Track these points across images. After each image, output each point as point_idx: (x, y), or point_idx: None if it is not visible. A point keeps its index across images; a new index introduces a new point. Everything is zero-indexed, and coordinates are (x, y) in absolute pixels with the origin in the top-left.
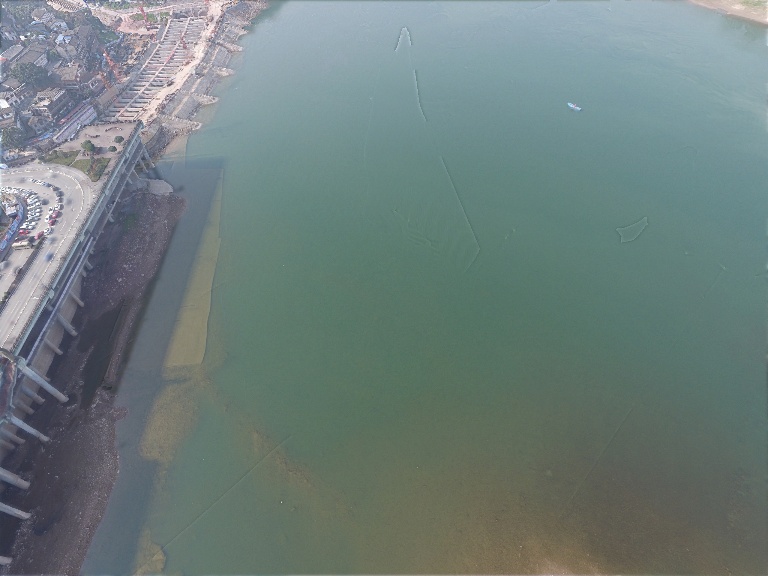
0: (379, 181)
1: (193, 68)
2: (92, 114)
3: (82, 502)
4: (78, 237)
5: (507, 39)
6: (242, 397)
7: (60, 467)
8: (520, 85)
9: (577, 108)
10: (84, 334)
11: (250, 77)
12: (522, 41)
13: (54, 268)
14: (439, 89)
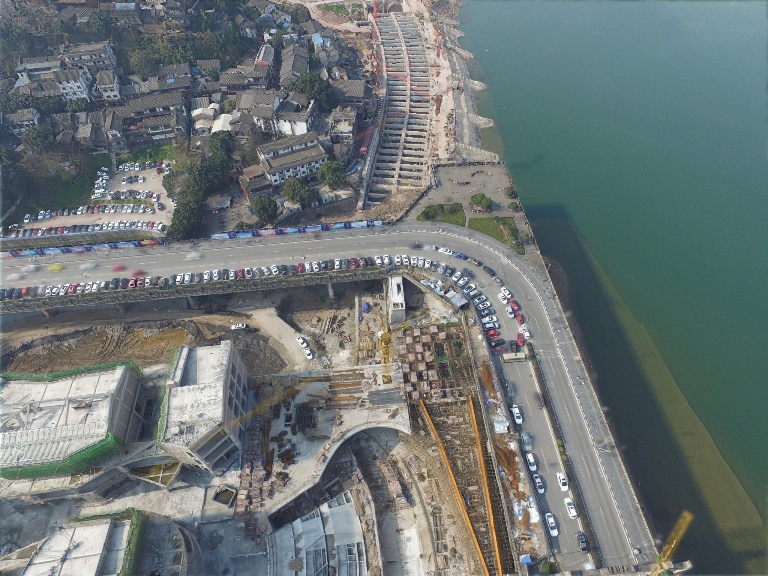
0: None
1: (456, 81)
2: (377, 139)
3: None
4: None
5: None
6: None
7: None
8: None
9: None
10: None
11: (511, 94)
12: None
13: (588, 398)
14: (752, 123)
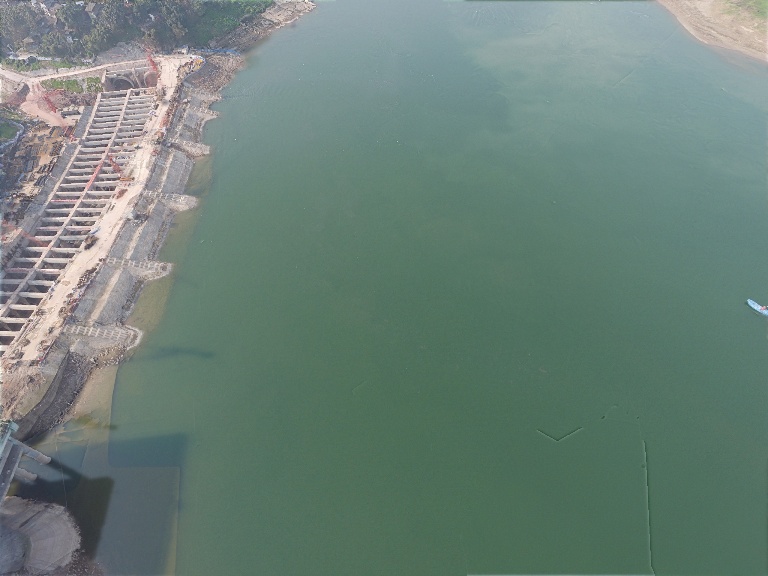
0: None
1: (129, 210)
2: None
3: None
4: None
5: (597, 140)
6: None
7: None
8: (649, 246)
9: (767, 316)
10: None
11: (223, 215)
12: (621, 146)
13: None
14: (526, 253)
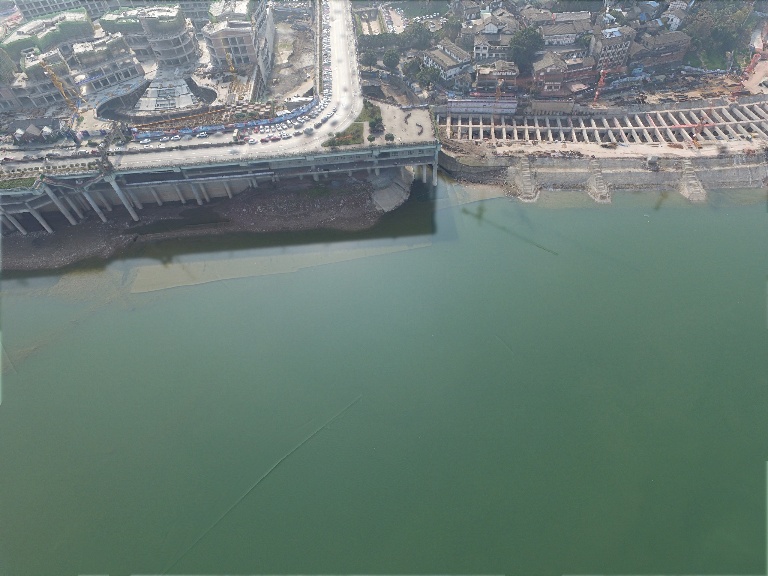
0: (294, 429)
1: (655, 154)
2: (511, 108)
3: (42, 254)
4: (238, 161)
5: None
6: (80, 331)
7: (78, 235)
8: None
9: None
10: (200, 209)
11: (689, 223)
12: None
13: (200, 160)
14: None
